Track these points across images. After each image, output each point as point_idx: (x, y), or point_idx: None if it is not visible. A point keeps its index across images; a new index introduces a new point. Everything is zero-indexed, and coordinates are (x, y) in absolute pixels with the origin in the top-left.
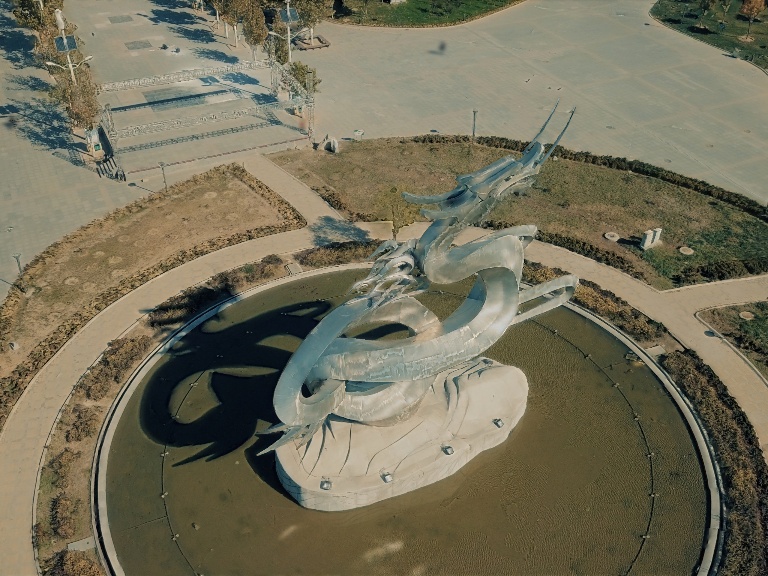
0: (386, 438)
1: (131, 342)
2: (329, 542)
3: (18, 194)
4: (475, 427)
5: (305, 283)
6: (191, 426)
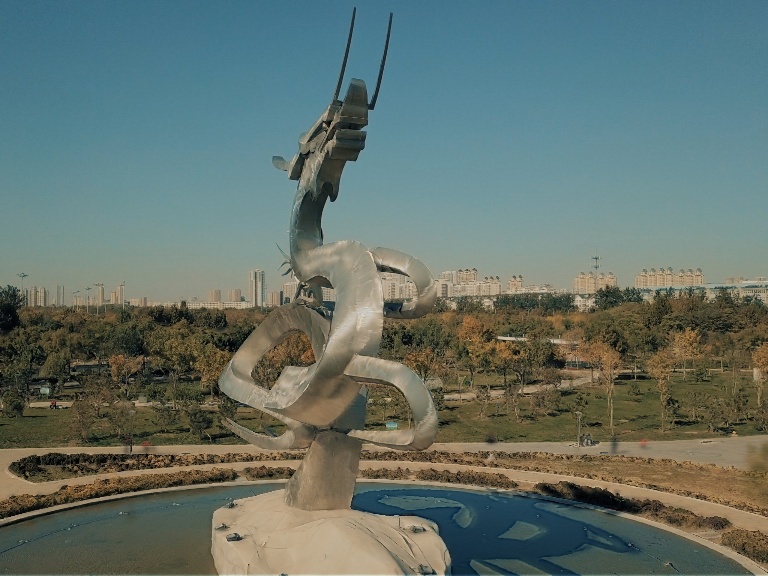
0: (271, 507)
1: (499, 476)
2: (177, 540)
3: (763, 453)
4: (280, 564)
5: (672, 539)
6: (374, 502)
